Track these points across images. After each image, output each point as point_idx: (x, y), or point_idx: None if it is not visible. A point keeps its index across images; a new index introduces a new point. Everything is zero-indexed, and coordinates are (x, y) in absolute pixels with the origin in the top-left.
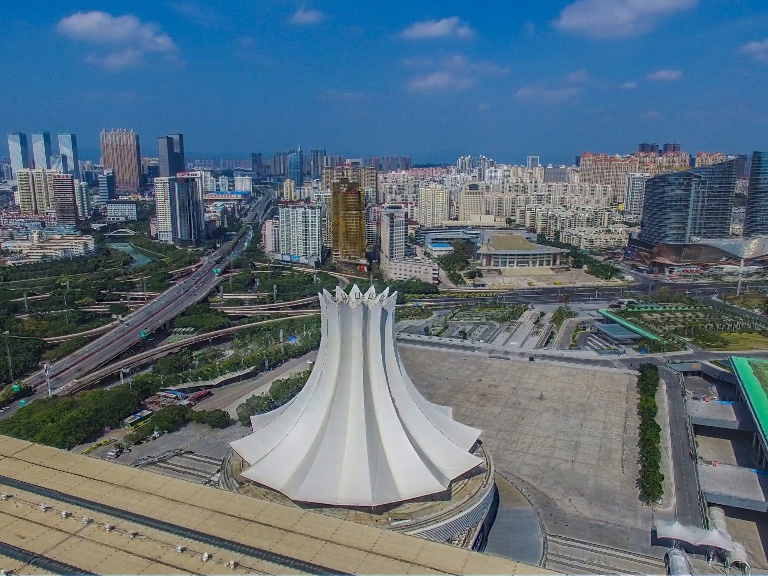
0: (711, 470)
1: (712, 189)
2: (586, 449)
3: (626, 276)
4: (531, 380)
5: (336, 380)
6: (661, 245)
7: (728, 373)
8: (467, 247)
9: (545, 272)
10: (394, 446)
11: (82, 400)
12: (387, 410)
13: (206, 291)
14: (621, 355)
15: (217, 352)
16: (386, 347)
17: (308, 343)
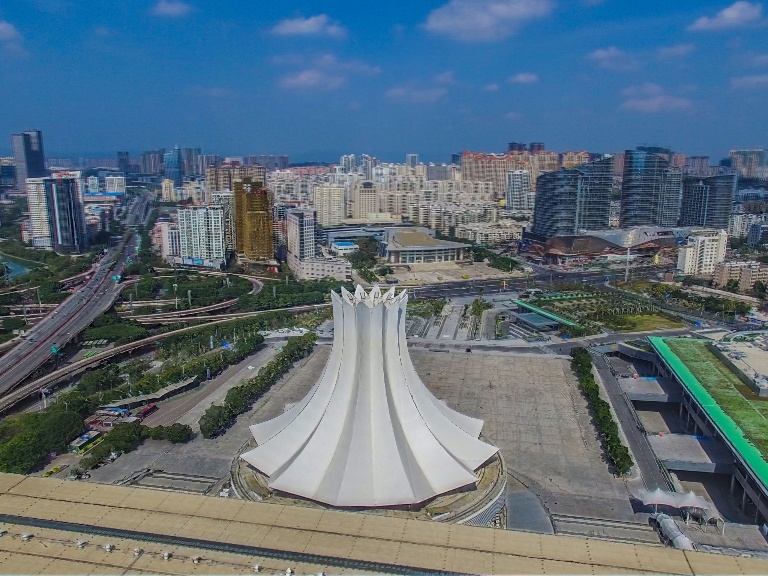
0: (660, 440)
1: (593, 185)
2: (548, 431)
3: (526, 268)
4: (476, 370)
5: (355, 381)
6: (554, 238)
7: (644, 352)
8: (370, 245)
9: (451, 267)
10: (419, 442)
11: (15, 426)
12: (408, 407)
13: (111, 300)
14: (547, 341)
15: (143, 364)
16: (400, 345)
17: (245, 348)
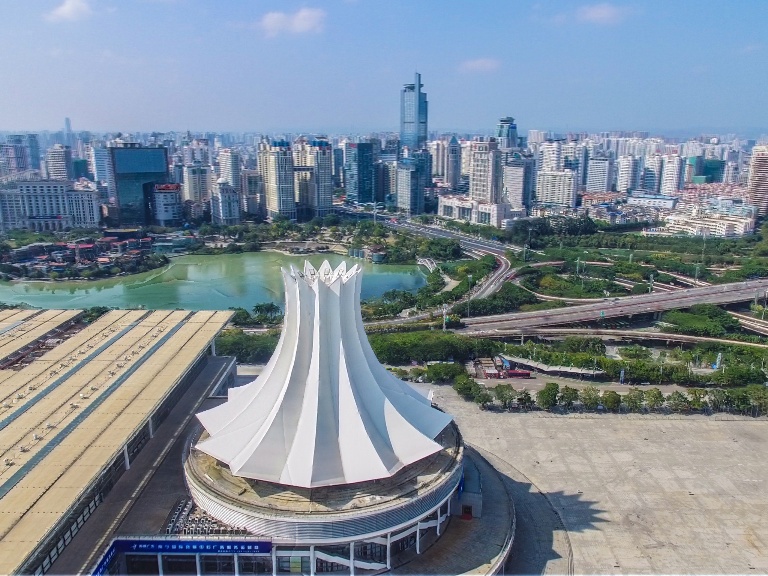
0: None
1: None
2: None
3: None
4: None
5: None
6: None
7: None
8: None
9: None
10: None
11: (432, 337)
12: None
13: None
14: None
15: (642, 353)
16: (315, 329)
17: (713, 376)
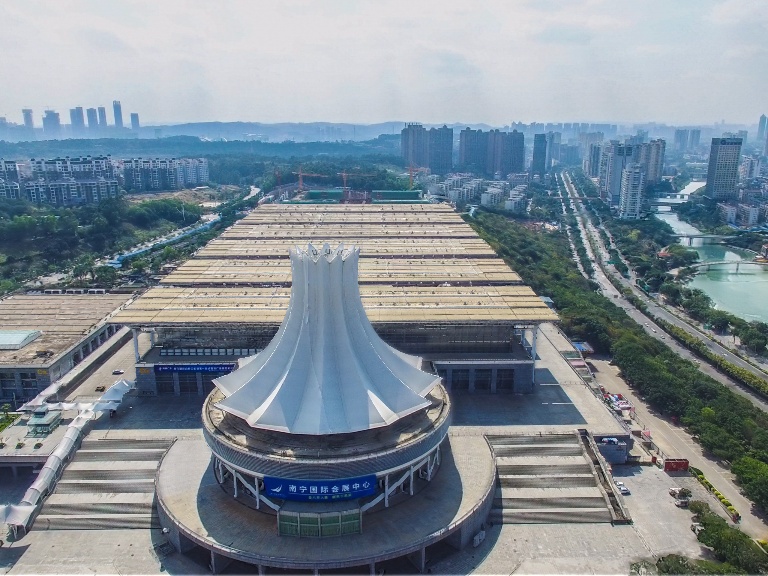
0: None
1: None
2: None
3: None
4: None
5: None
6: None
7: None
8: None
9: None
10: None
11: None
12: None
13: None
14: None
15: None
16: None
17: None
